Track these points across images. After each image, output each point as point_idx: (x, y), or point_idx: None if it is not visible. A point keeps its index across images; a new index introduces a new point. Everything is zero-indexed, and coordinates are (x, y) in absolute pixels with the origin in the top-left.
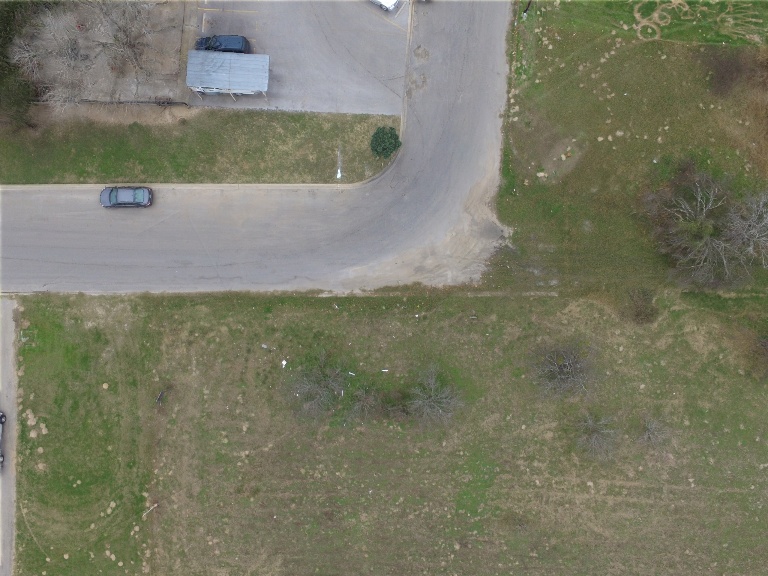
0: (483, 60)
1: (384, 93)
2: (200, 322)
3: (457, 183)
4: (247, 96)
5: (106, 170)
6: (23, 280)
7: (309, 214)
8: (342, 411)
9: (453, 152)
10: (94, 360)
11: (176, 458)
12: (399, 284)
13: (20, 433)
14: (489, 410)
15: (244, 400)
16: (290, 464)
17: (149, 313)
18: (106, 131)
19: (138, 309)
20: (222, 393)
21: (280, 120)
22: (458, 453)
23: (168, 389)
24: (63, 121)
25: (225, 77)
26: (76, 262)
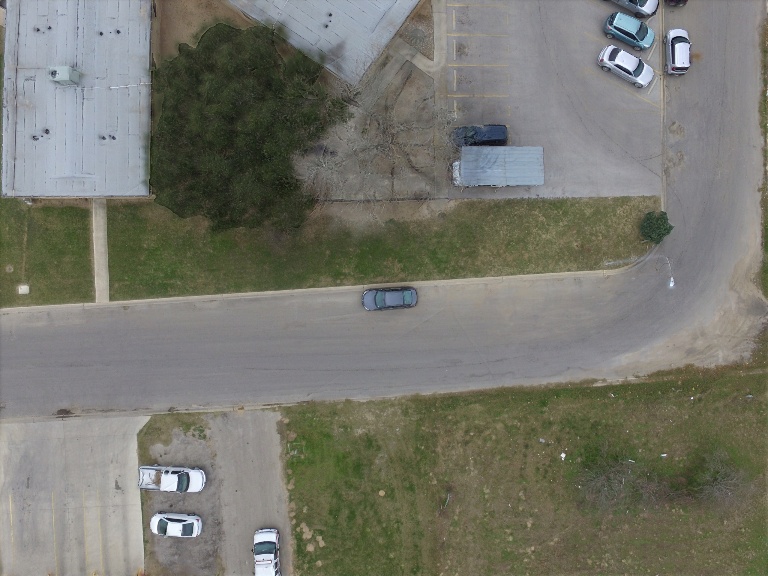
0: (739, 134)
1: (643, 173)
2: (475, 421)
3: (722, 261)
4: (509, 186)
5: (364, 271)
6: (285, 391)
7: (577, 303)
8: (624, 499)
9: (715, 230)
10: (367, 468)
11: (461, 560)
12: (672, 367)
13: (295, 548)
14: (767, 485)
15: (526, 496)
16: (576, 556)
17: (421, 416)
18: (362, 231)
19: (409, 412)
20: (503, 491)
21: (542, 208)
22: (739, 530)
23: (448, 492)
24: (316, 223)
25: (501, 173)
26: (340, 369)
